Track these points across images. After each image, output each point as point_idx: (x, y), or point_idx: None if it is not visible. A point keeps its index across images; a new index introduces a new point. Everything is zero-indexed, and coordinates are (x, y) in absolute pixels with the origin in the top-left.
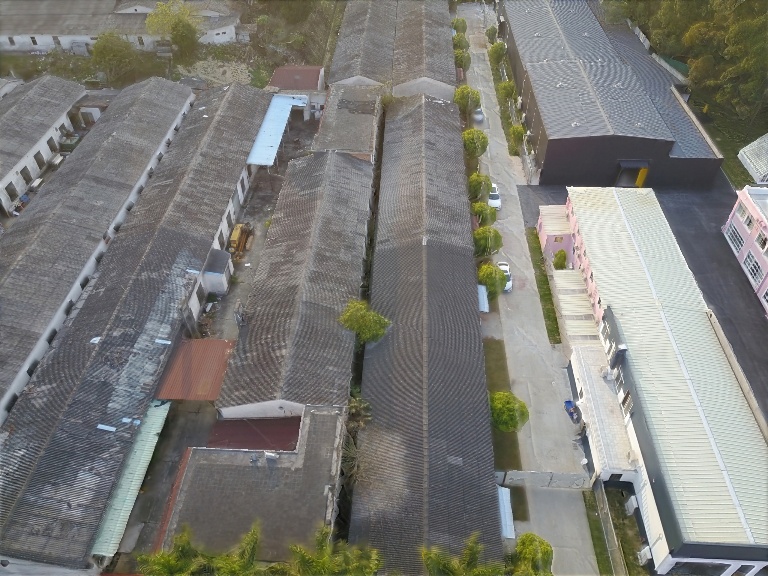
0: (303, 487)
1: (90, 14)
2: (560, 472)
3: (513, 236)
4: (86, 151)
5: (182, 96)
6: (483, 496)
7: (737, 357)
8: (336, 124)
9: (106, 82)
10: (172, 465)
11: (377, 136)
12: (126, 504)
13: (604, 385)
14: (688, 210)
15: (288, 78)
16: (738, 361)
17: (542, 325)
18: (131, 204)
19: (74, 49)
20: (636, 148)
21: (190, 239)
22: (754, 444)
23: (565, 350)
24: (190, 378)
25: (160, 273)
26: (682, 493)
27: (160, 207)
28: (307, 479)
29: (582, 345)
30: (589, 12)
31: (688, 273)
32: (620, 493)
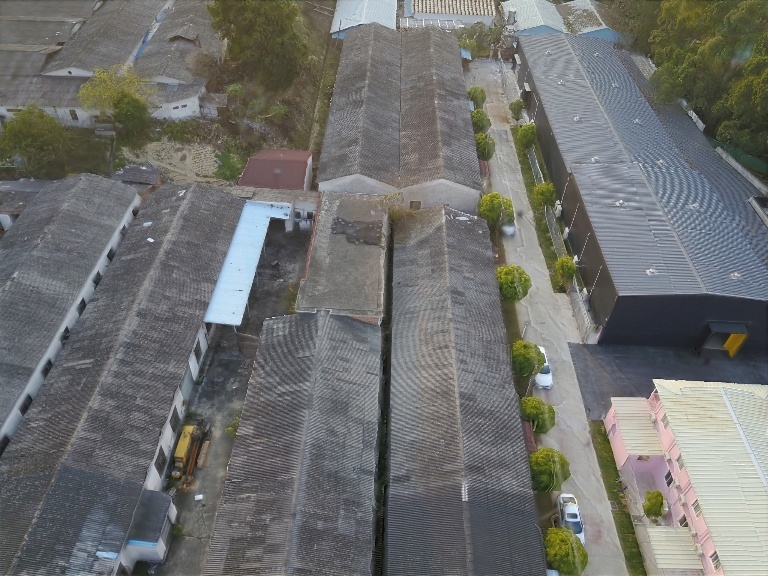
0: None
1: (9, 75)
2: None
3: (573, 437)
4: None
5: (122, 203)
6: None
7: None
8: (330, 262)
9: (25, 169)
10: None
11: None
12: None
13: None
14: None
15: (266, 172)
16: None
17: None
18: (28, 400)
19: None
20: (733, 308)
21: (108, 485)
22: None
23: None
24: None
25: (51, 568)
26: None
27: (67, 419)
28: None
29: None
30: (634, 87)
31: None
32: None
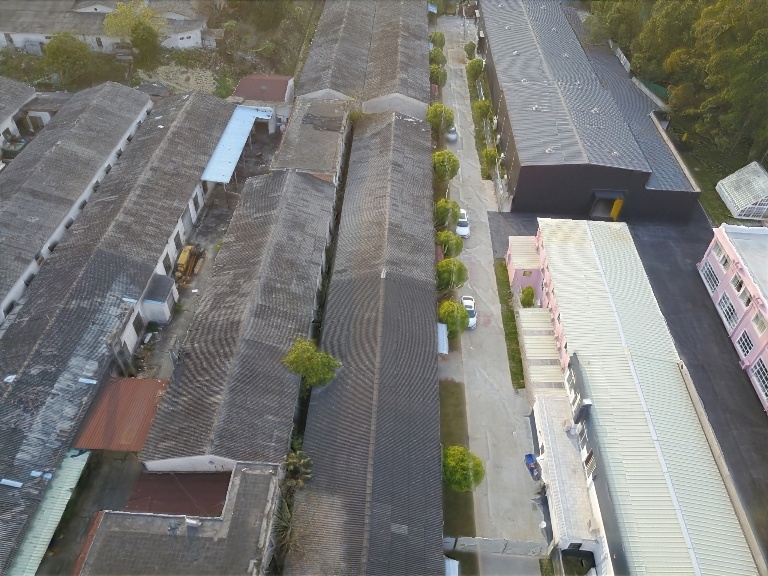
0: (225, 562)
1: (46, 11)
2: (516, 536)
3: (481, 267)
4: (26, 161)
5: (138, 103)
6: (428, 571)
7: (709, 408)
8: (299, 141)
9: (60, 84)
10: (89, 522)
11: (343, 154)
12: (25, 575)
13: (567, 440)
14: (663, 244)
15: (254, 88)
16: (709, 412)
17: (506, 367)
18: (71, 221)
19: (27, 48)
20: (611, 178)
21: (130, 263)
22: (723, 517)
23: (529, 396)
24: (114, 424)
25: (92, 302)
26: (644, 573)
27: (100, 226)
28: (230, 552)
29: (546, 394)
30: (570, 31)
31: (660, 318)
32: (579, 562)
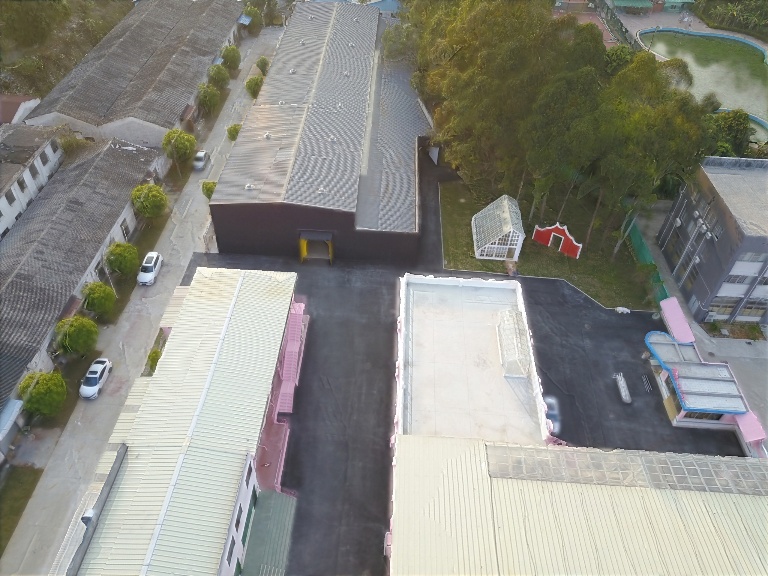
0: None
1: None
2: None
3: (147, 321)
4: None
5: None
6: None
7: (327, 497)
8: None
9: None
10: None
11: None
12: None
13: None
14: (374, 291)
15: None
16: (325, 503)
17: None
18: None
19: None
20: (314, 217)
21: None
22: None
23: None
24: None
25: None
26: None
27: None
28: None
29: None
30: (370, 46)
31: (263, 395)
32: None
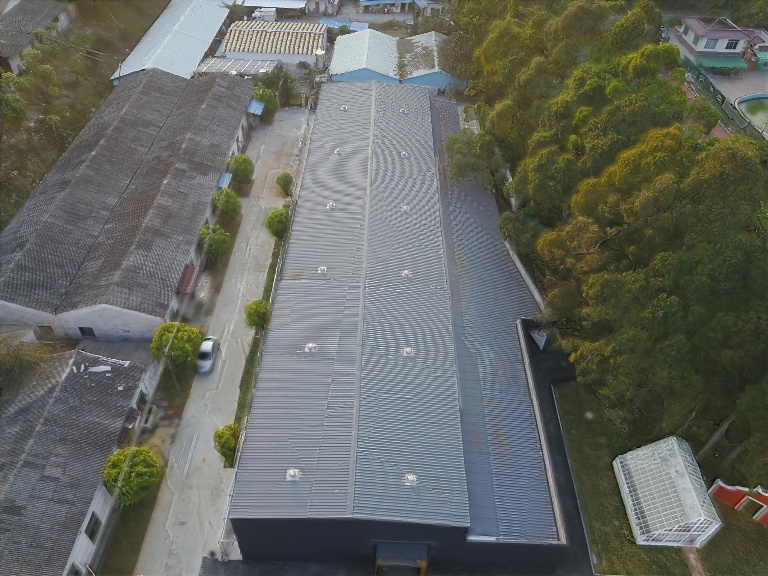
0: None
1: None
2: None
3: None
4: None
5: None
6: None
7: None
8: None
9: None
10: None
11: None
12: None
13: None
14: None
15: None
16: None
17: None
18: None
19: None
20: (401, 528)
21: None
22: None
23: None
24: None
25: None
26: None
27: None
28: None
29: None
30: (429, 155)
31: None
32: None
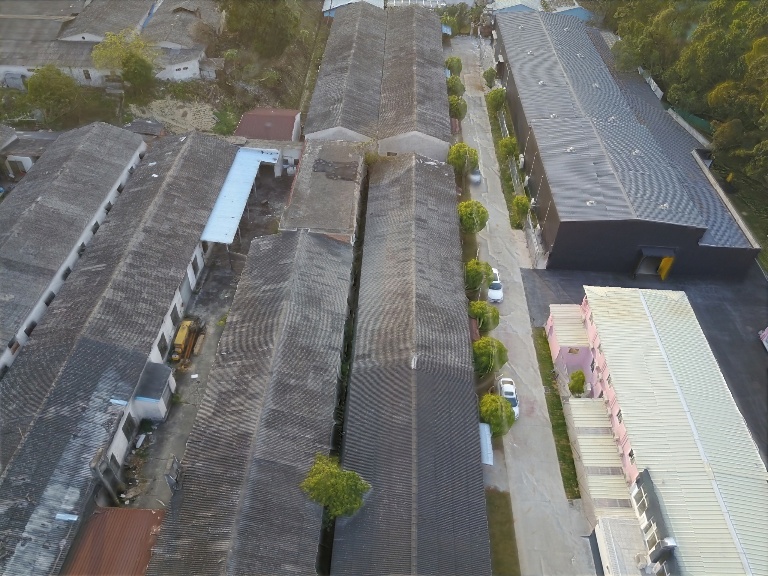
0: None
1: (29, 40)
2: None
3: (518, 339)
4: (2, 221)
5: (130, 147)
6: None
7: None
8: (310, 193)
9: (44, 122)
10: None
11: (359, 203)
12: None
13: None
14: (719, 308)
15: (258, 125)
16: None
17: (556, 470)
18: (51, 295)
19: (7, 81)
20: (661, 234)
21: (119, 353)
22: None
23: (586, 509)
24: None
25: (74, 407)
26: None
27: (85, 305)
28: None
29: (611, 516)
30: (597, 57)
31: (738, 418)
32: None
